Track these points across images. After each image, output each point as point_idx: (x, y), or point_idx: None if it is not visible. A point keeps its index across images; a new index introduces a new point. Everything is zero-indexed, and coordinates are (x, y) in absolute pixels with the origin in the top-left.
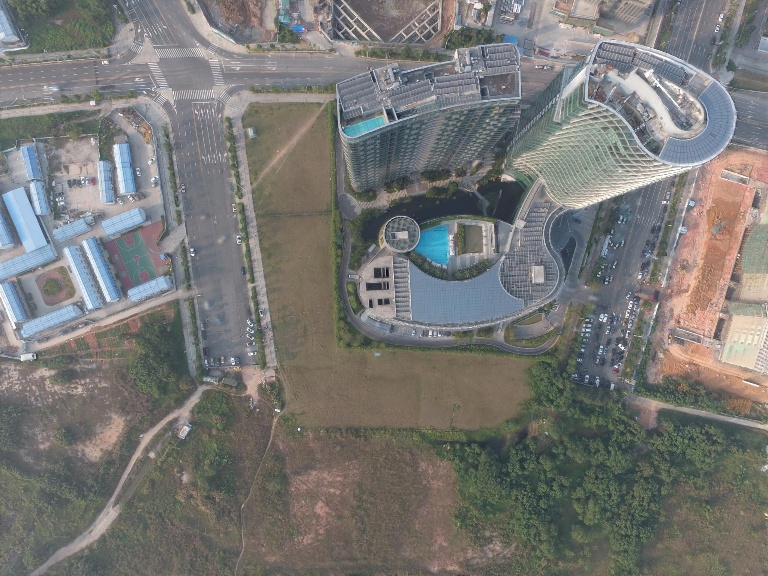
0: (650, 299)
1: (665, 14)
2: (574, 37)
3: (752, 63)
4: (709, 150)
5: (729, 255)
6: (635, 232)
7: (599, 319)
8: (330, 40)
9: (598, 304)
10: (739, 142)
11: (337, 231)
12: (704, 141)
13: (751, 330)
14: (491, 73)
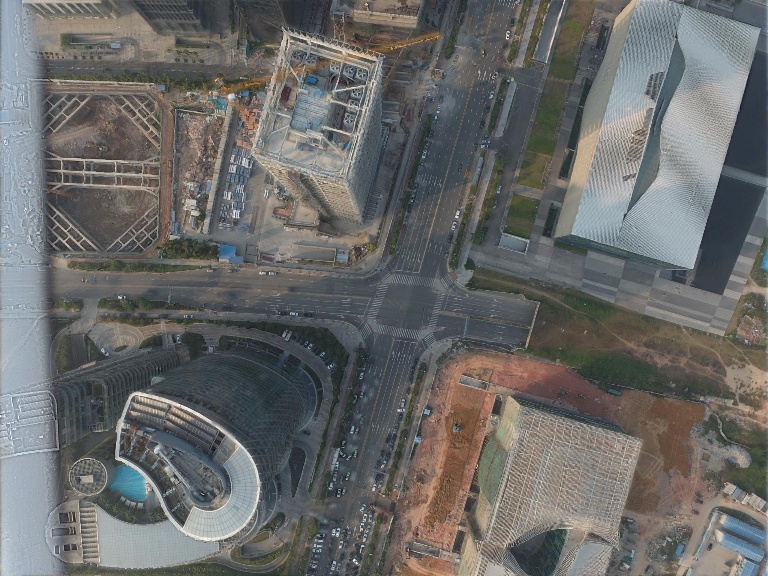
0: (386, 511)
1: (397, 212)
2: (301, 239)
3: (492, 261)
4: (232, 525)
5: (469, 464)
6: (369, 442)
7: (331, 534)
8: (41, 253)
9: (331, 518)
10: (479, 345)
11: (48, 454)
12: (227, 514)
13: (474, 558)
14: (26, 423)
